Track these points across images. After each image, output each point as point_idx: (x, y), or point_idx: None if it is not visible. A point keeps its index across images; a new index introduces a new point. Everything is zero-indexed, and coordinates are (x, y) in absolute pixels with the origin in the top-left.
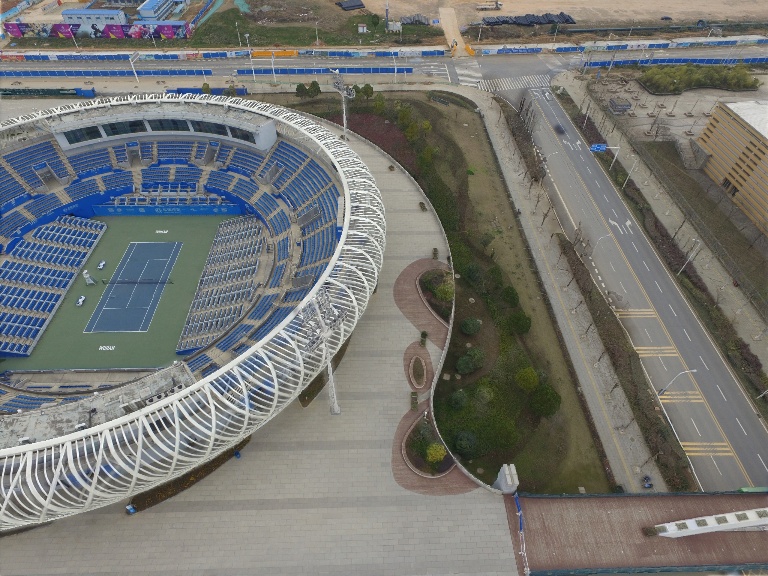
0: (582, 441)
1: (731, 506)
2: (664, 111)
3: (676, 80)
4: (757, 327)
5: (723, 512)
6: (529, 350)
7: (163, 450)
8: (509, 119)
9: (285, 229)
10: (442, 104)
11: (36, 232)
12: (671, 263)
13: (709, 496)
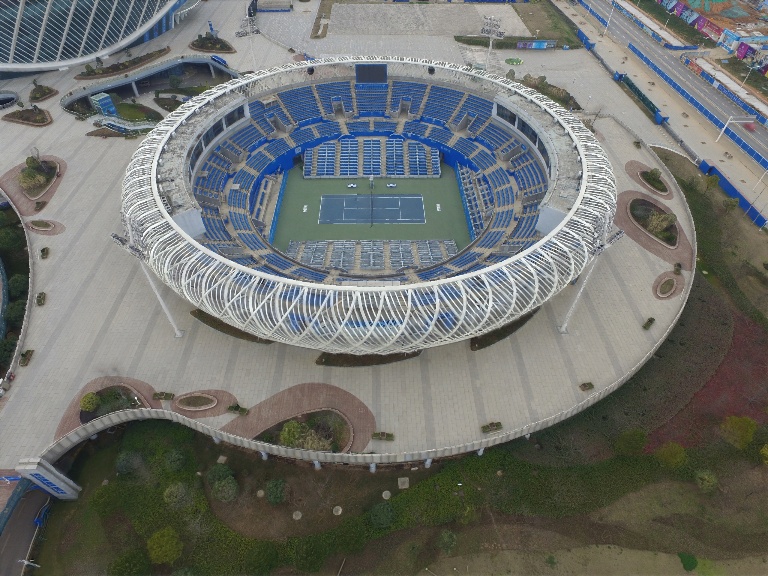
0: None
1: None
2: None
3: None
4: None
5: None
6: None
7: None
8: None
9: (421, 277)
10: None
11: (414, 143)
12: None
13: None
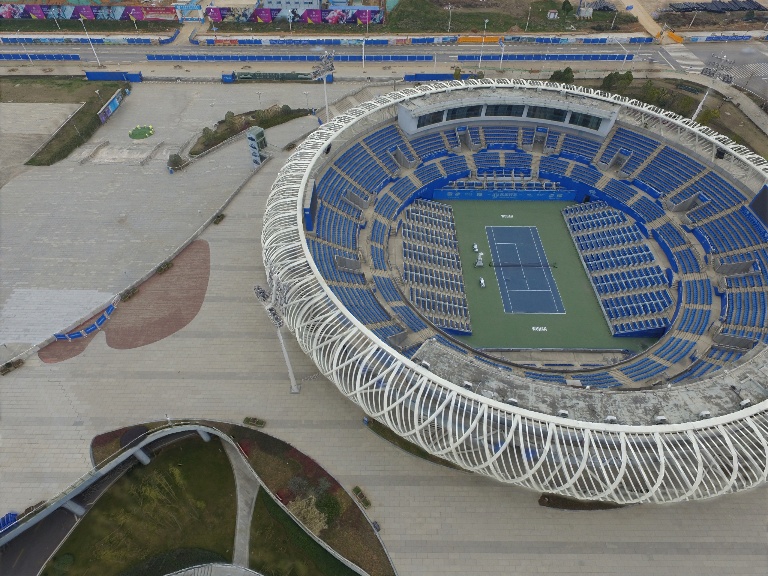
0: None
1: None
2: None
3: None
4: None
5: None
6: None
7: None
8: None
9: (660, 216)
10: (689, 92)
11: (407, 214)
12: None
13: None
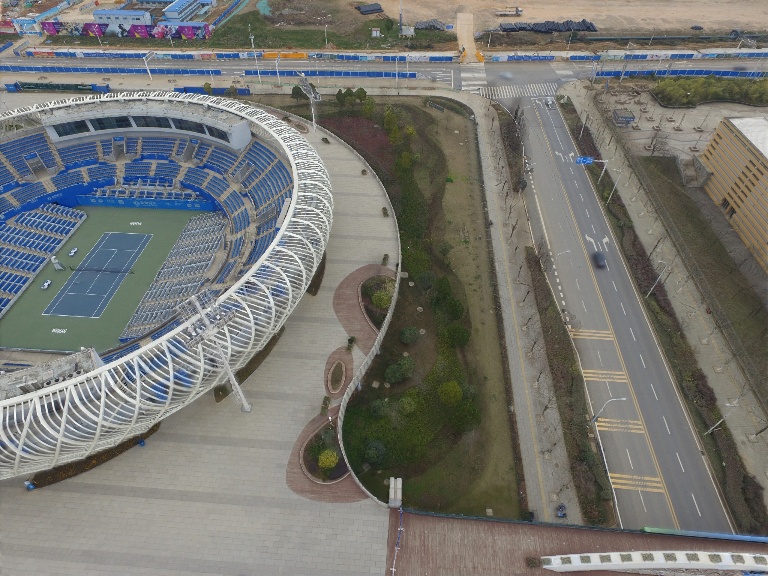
0: (502, 462)
1: (631, 545)
2: (672, 125)
3: (690, 93)
4: (722, 358)
5: (620, 551)
6: (468, 364)
7: (48, 431)
8: (502, 127)
9: (244, 227)
10: (437, 110)
11: (19, 218)
12: (641, 284)
13: (608, 532)
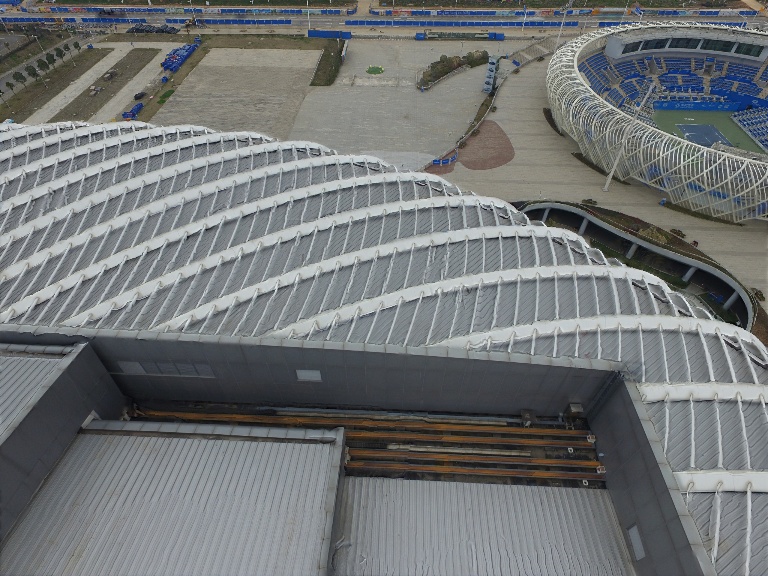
0: None
1: None
2: None
3: None
4: None
5: None
6: None
7: None
8: None
9: None
10: None
11: None
12: None
13: None
